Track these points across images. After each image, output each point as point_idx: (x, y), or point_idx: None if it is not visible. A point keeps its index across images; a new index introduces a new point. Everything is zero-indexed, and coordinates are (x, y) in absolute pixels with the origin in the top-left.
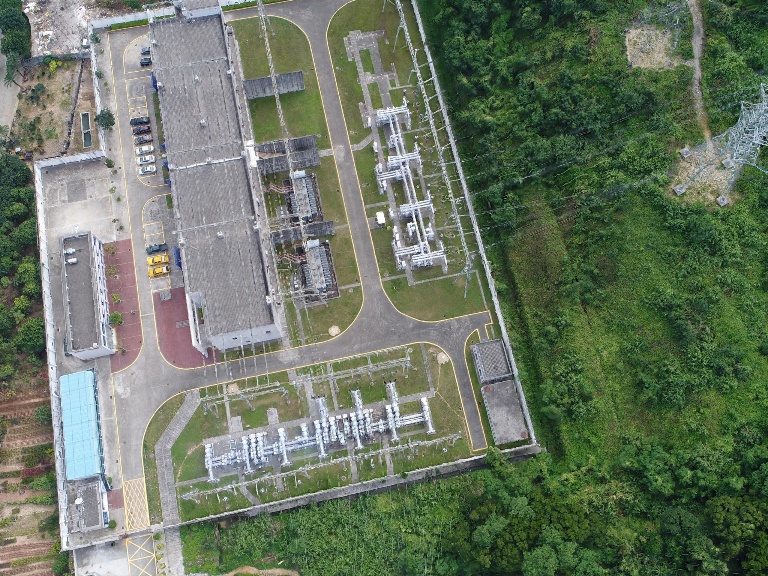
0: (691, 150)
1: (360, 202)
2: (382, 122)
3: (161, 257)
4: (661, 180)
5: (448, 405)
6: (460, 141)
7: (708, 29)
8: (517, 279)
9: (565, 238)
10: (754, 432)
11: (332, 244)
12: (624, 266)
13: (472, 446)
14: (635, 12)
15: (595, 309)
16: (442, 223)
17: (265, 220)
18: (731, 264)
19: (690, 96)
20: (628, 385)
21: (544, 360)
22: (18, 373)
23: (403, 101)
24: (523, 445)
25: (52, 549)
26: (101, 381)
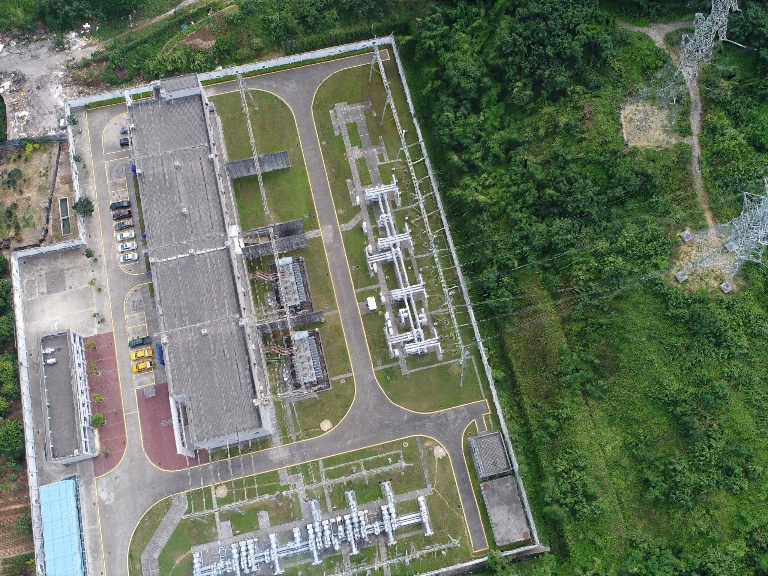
0: (692, 233)
1: (350, 286)
2: (371, 200)
3: (144, 351)
4: (662, 267)
5: (446, 503)
6: (452, 218)
7: (706, 104)
8: (515, 367)
9: (563, 324)
10: (767, 536)
11: (322, 332)
12: (626, 357)
13: (472, 547)
14: (630, 87)
15: (597, 400)
16: (436, 306)
17: (251, 317)
18: (737, 355)
19: (689, 175)
20: (633, 482)
21: (545, 454)
22: None
23: (392, 178)
24: (525, 545)
25: None
26: (84, 486)
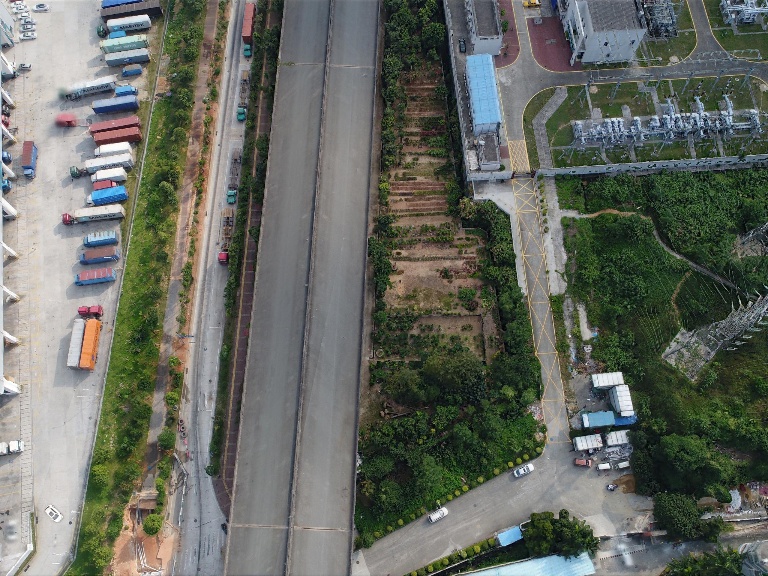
0: None
1: None
2: None
3: None
4: None
5: None
6: None
7: None
8: None
9: None
10: None
11: None
12: None
13: None
14: None
15: None
16: None
17: None
18: None
19: None
20: None
21: None
22: (416, 65)
23: None
24: None
25: (448, 185)
26: None
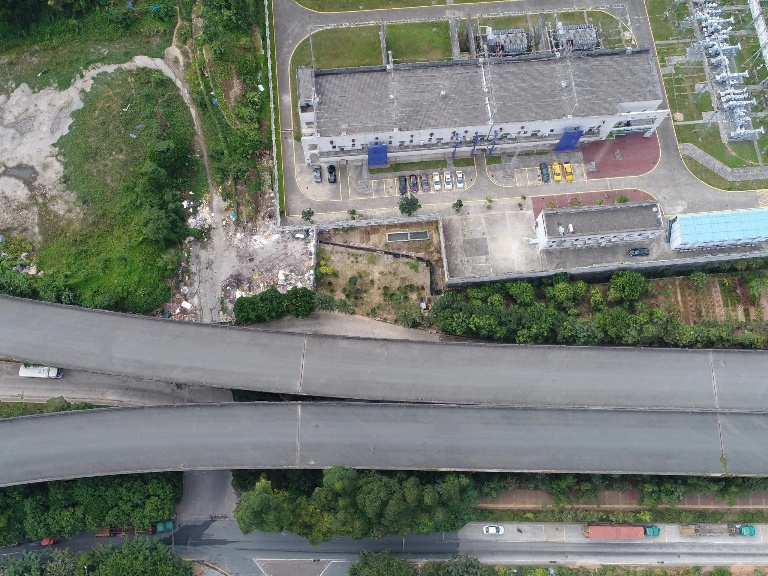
0: None
1: (506, 3)
2: None
3: (555, 168)
4: None
5: None
6: None
7: None
8: None
9: None
10: None
11: None
12: None
13: None
14: None
15: None
16: None
17: None
18: None
19: None
20: None
21: None
22: None
23: None
24: None
25: None
26: None
